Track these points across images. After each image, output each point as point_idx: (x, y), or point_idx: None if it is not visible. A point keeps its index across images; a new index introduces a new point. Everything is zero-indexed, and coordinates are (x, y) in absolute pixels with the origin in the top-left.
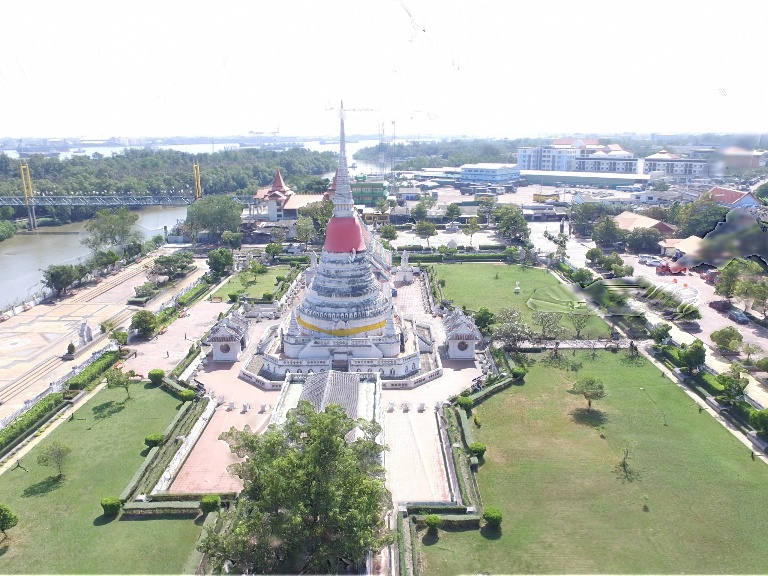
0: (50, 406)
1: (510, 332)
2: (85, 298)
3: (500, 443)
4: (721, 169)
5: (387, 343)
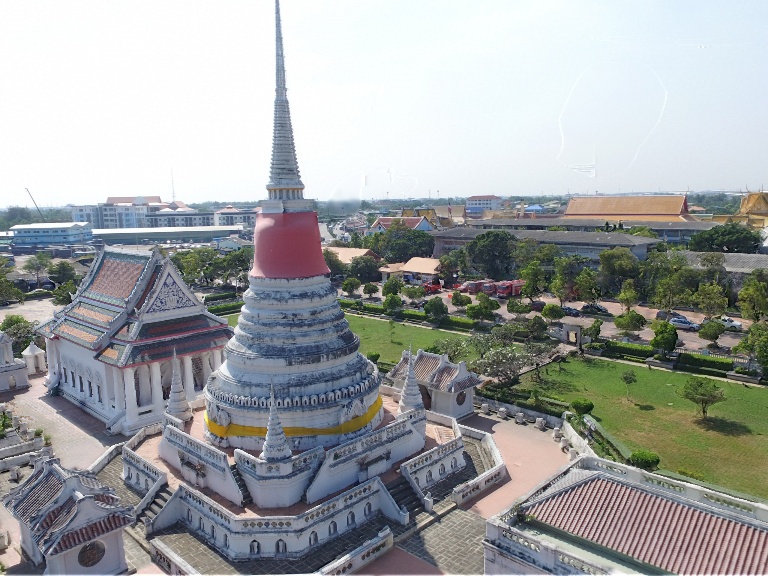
0: None
1: (512, 361)
2: None
3: (767, 492)
4: (338, 209)
5: (421, 419)
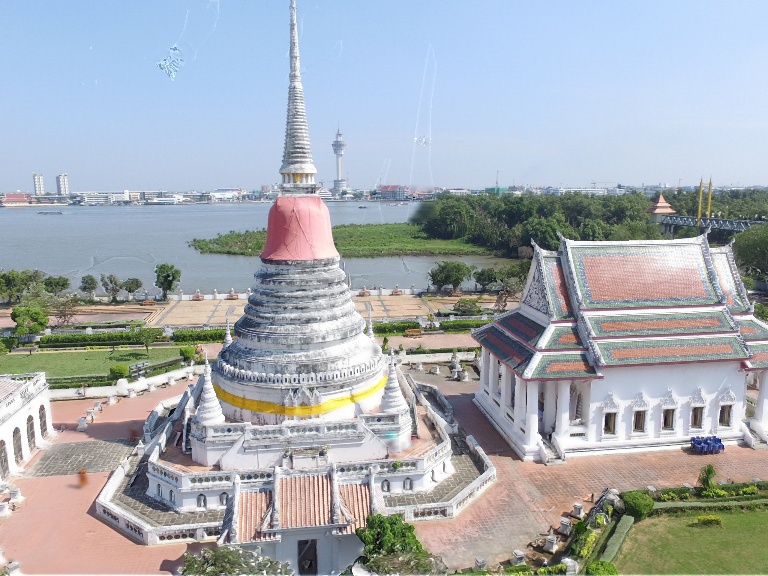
0: (129, 337)
1: None
2: (451, 301)
3: None
4: None
5: None
